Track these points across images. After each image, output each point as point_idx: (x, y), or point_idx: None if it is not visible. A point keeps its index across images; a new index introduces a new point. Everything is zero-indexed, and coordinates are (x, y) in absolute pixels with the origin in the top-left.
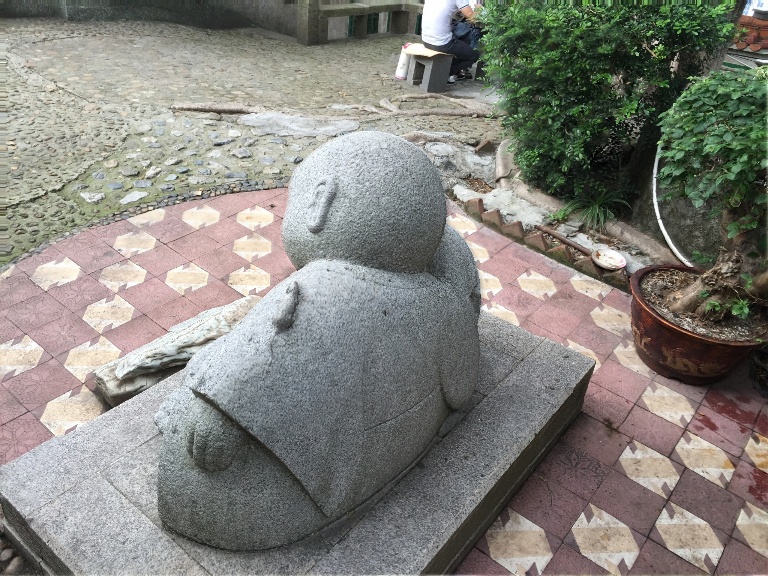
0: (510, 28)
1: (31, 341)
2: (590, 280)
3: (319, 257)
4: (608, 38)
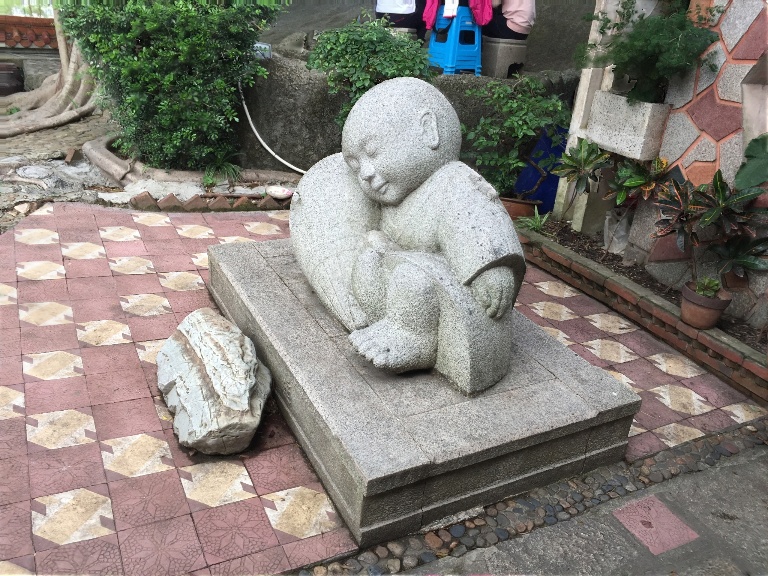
0: (137, 24)
1: (54, 496)
2: (278, 212)
3: (441, 165)
4: (231, 19)
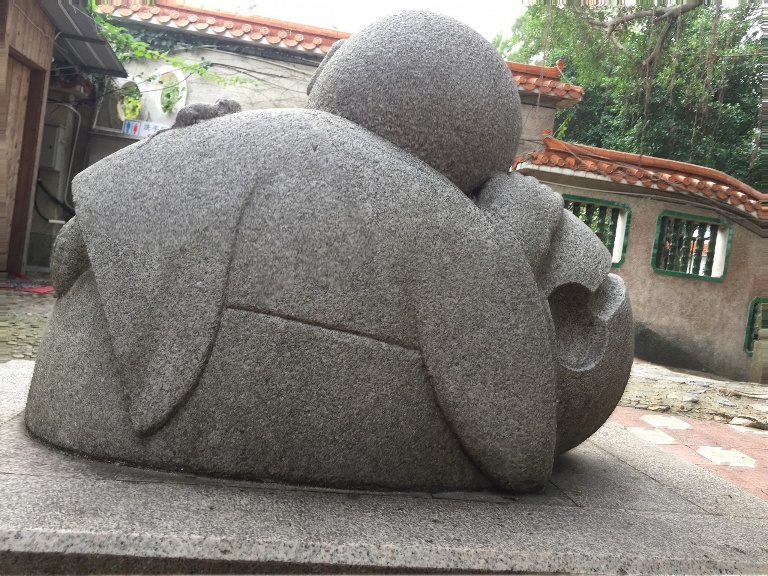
0: None
1: None
2: None
3: None
4: None
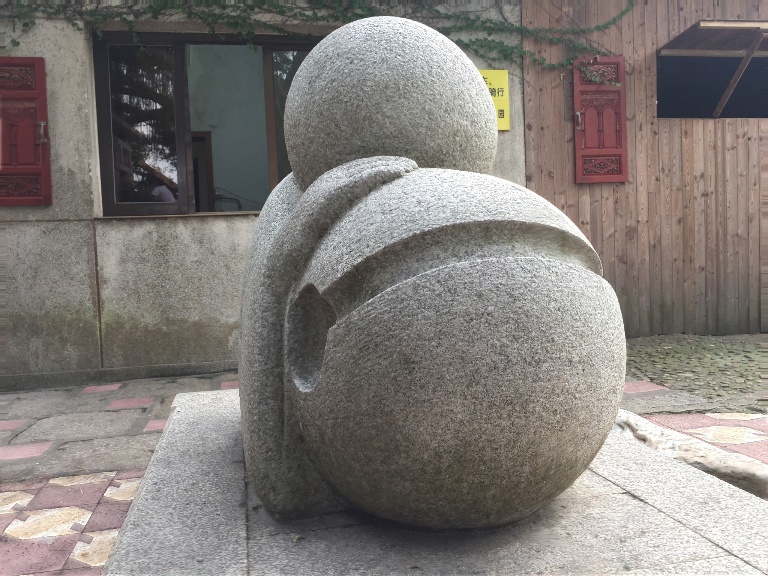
0: None
1: (761, 439)
2: None
3: None
4: None
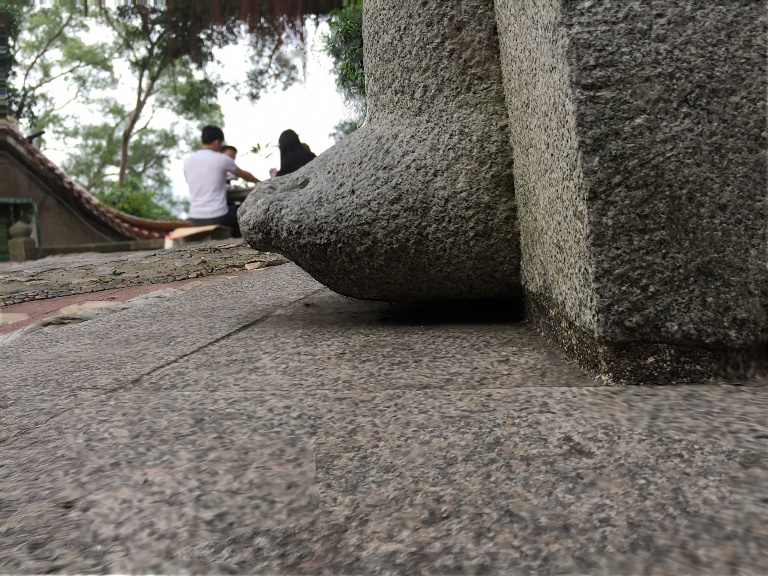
0: None
1: None
2: None
3: None
4: None
